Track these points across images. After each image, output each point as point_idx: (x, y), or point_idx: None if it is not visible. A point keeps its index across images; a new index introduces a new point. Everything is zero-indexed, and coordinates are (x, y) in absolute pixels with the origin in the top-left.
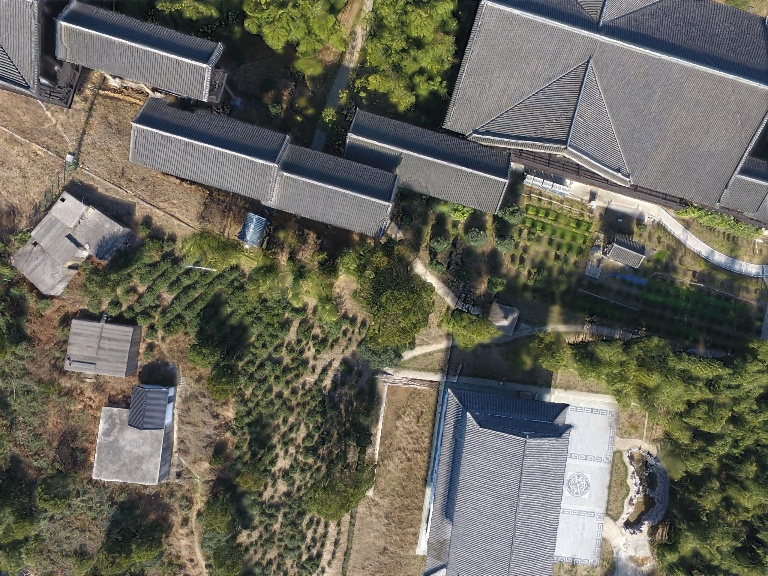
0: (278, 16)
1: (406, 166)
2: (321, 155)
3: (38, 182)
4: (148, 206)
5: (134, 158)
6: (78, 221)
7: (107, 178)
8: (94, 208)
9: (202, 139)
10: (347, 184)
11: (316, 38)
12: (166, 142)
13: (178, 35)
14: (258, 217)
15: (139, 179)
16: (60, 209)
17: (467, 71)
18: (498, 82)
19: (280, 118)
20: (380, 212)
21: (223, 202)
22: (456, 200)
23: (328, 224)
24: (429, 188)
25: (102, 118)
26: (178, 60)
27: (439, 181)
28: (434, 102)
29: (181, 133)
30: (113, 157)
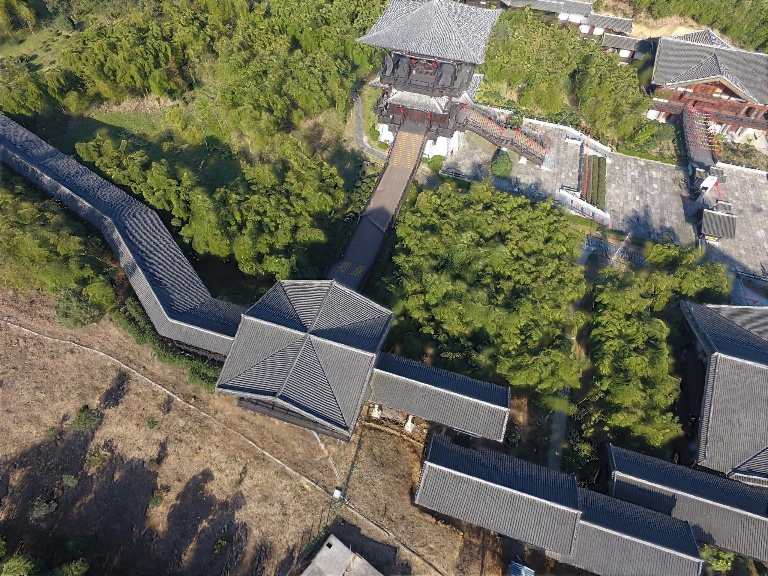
0: (532, 361)
1: (682, 509)
2: (599, 496)
3: (298, 521)
4: (408, 552)
5: (420, 499)
6: (343, 574)
7: (370, 517)
8: (361, 556)
9: (496, 480)
10: (642, 533)
11: (558, 378)
12: (458, 482)
13: (470, 380)
14: (527, 569)
15: (399, 518)
16: (325, 557)
17: (712, 411)
18: (747, 422)
19: (515, 448)
20: (689, 571)
21: (475, 545)
22: (748, 552)
23: (580, 574)
24: (713, 536)
25: (368, 450)
26: (478, 403)
27: (723, 528)
28: (665, 435)
29: (474, 473)
30: (377, 492)
